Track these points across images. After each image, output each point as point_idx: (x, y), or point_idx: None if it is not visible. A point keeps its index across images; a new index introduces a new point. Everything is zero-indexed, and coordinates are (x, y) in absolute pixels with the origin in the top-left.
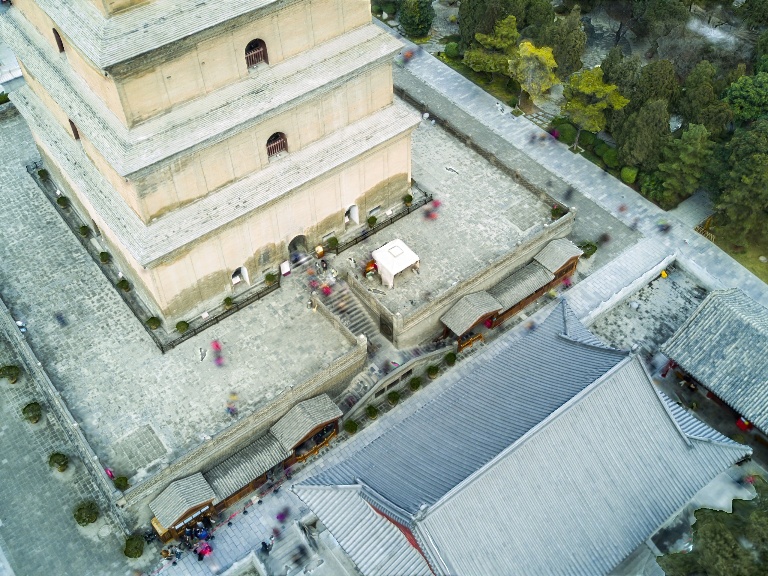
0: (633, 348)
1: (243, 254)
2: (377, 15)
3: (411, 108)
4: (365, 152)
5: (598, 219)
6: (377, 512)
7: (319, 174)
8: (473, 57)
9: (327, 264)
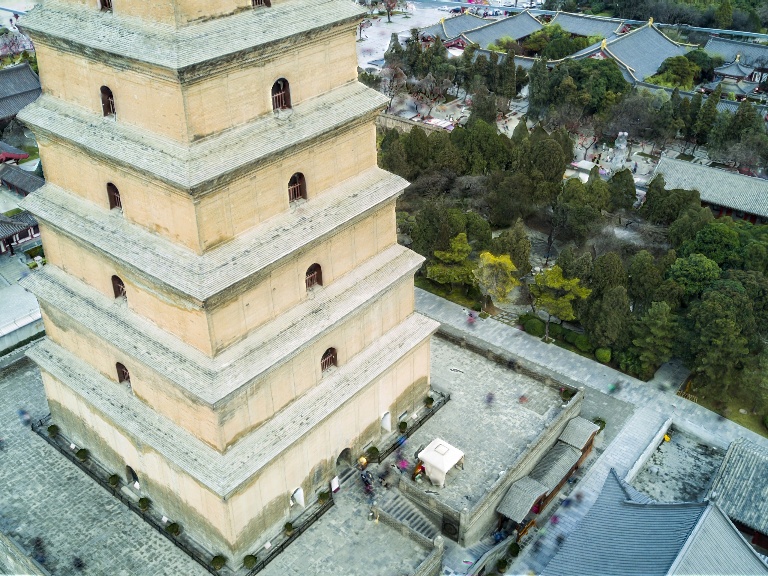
0: (713, 496)
1: (301, 474)
2: None
3: None
4: (399, 359)
5: (592, 398)
6: None
7: (366, 384)
8: (436, 271)
9: (372, 474)
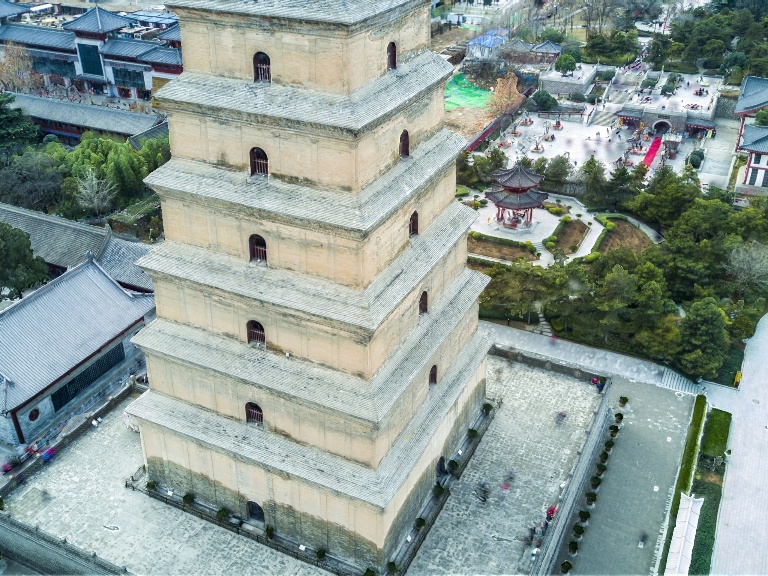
0: None
1: None
2: None
3: None
4: None
5: None
6: None
7: None
8: None
9: None
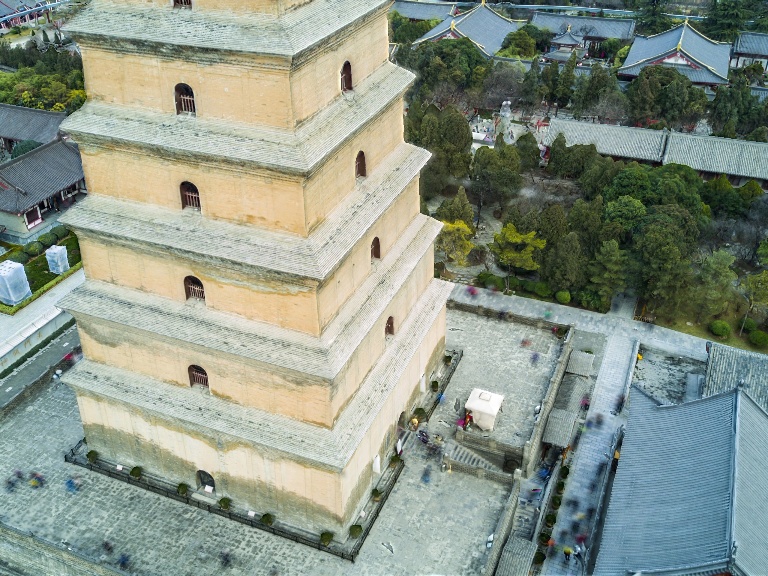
0: (743, 382)
1: (379, 441)
2: None
3: None
4: None
5: None
6: None
7: None
8: None
9: (426, 433)
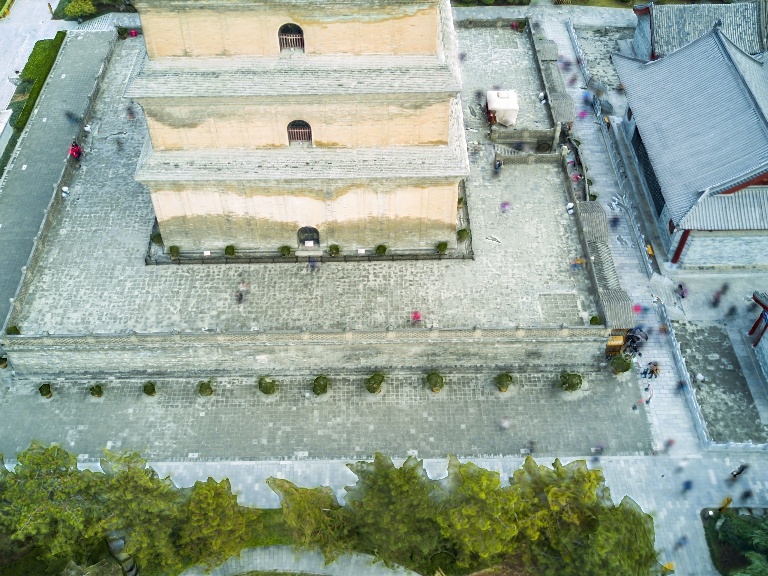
0: None
1: None
2: None
3: None
4: None
5: None
6: (731, 193)
7: None
8: None
9: None
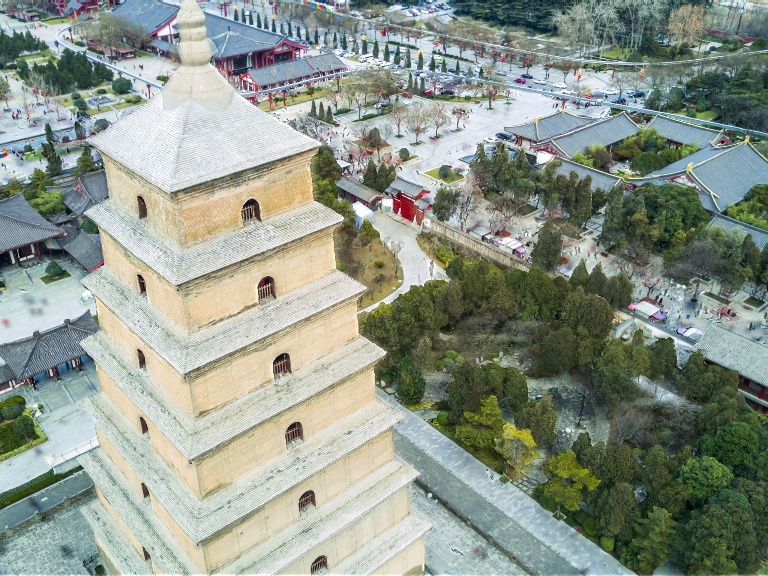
0: None
1: None
2: (376, 383)
3: (416, 487)
4: (389, 559)
5: None
6: None
7: None
8: (464, 432)
9: None
